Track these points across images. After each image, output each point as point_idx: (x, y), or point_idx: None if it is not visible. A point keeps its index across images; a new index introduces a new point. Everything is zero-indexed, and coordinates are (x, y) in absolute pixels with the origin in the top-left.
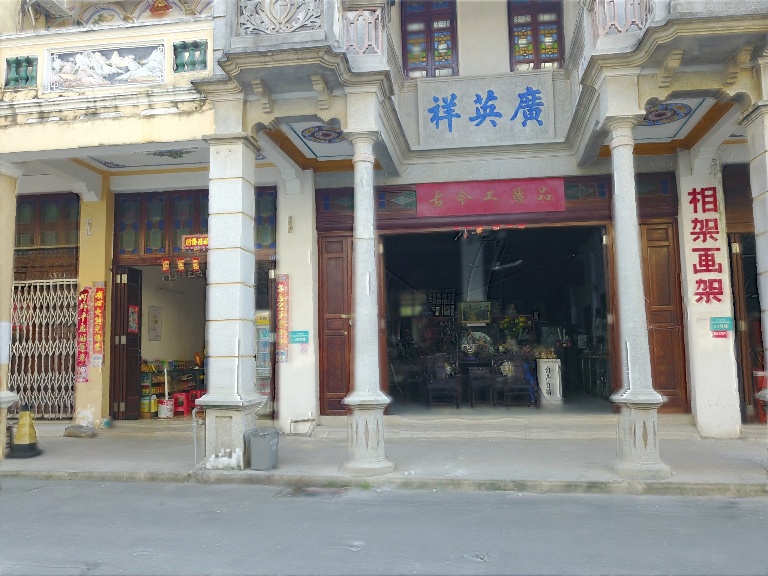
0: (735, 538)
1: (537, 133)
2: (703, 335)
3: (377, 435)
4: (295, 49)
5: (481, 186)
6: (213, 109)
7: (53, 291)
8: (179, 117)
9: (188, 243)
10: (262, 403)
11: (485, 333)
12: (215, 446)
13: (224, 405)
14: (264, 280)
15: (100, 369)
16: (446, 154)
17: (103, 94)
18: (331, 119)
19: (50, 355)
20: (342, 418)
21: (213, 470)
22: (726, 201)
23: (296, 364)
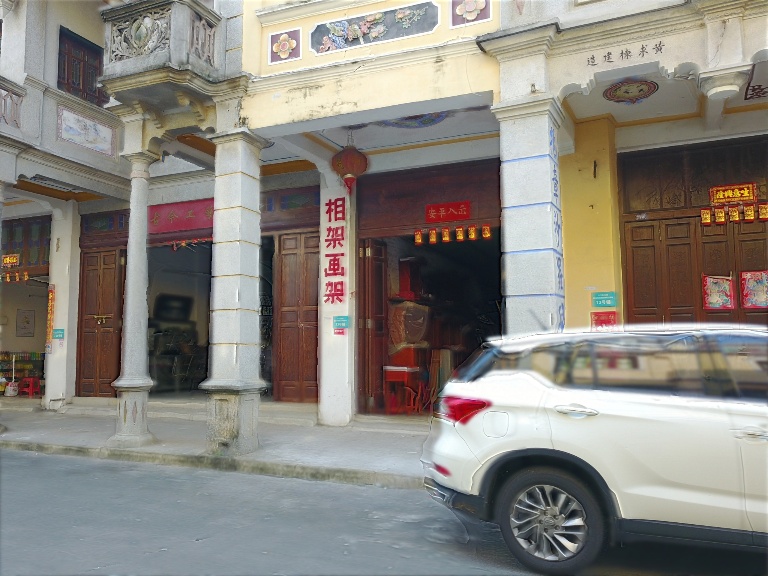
0: (18, 483)
1: None
2: (327, 332)
3: None
4: None
5: (185, 206)
6: None
7: None
8: None
9: (5, 261)
10: None
11: None
12: None
13: None
14: None
15: None
16: (158, 181)
17: None
18: None
19: None
20: (87, 399)
21: None
22: (363, 209)
23: (56, 355)
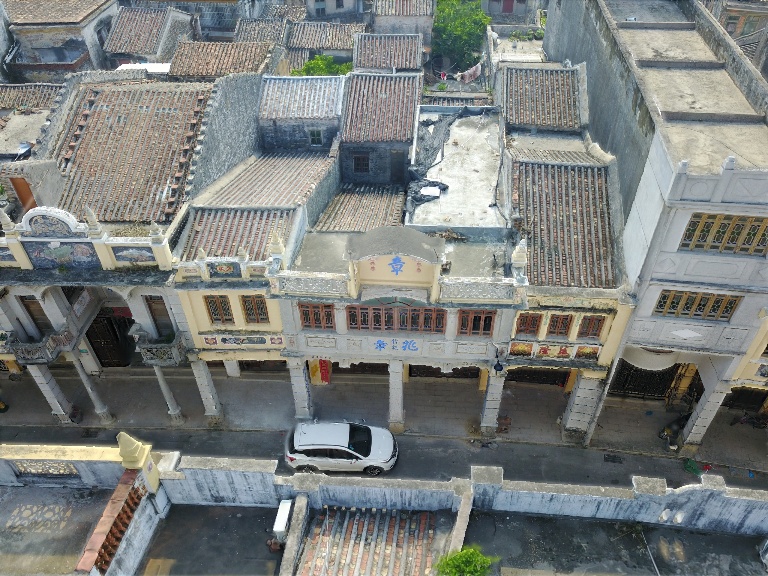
0: None
1: None
2: None
3: (107, 416)
4: None
5: None
6: None
7: None
8: (8, 354)
9: None
10: None
11: None
12: None
13: None
14: None
15: None
16: None
17: None
18: None
19: None
20: (110, 368)
21: (64, 424)
22: None
23: (86, 358)
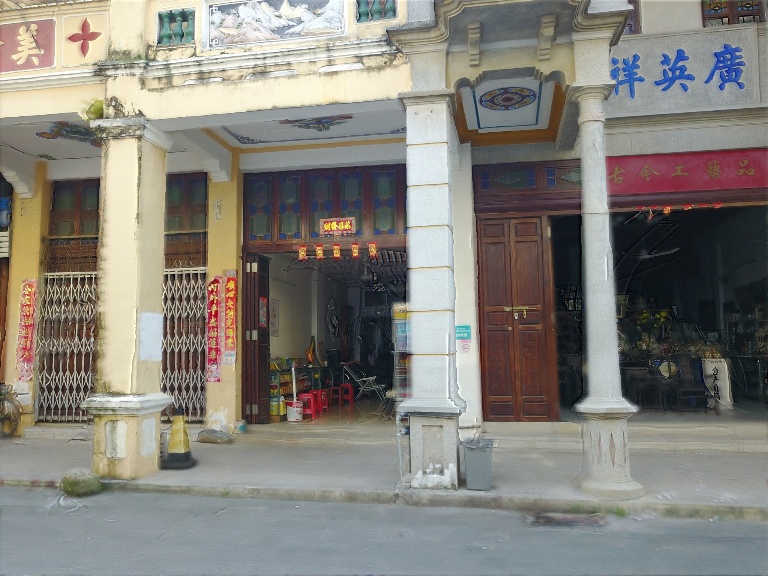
0: None
1: (738, 97)
2: None
3: (623, 450)
4: None
5: (669, 160)
6: (409, 63)
7: (178, 281)
8: (368, 73)
9: (327, 227)
10: None
11: (619, 329)
12: (422, 460)
13: (435, 412)
14: (340, 274)
15: (233, 367)
16: (629, 123)
17: (274, 49)
18: (552, 72)
19: (176, 351)
20: (510, 425)
21: (422, 489)
22: None
23: (457, 363)
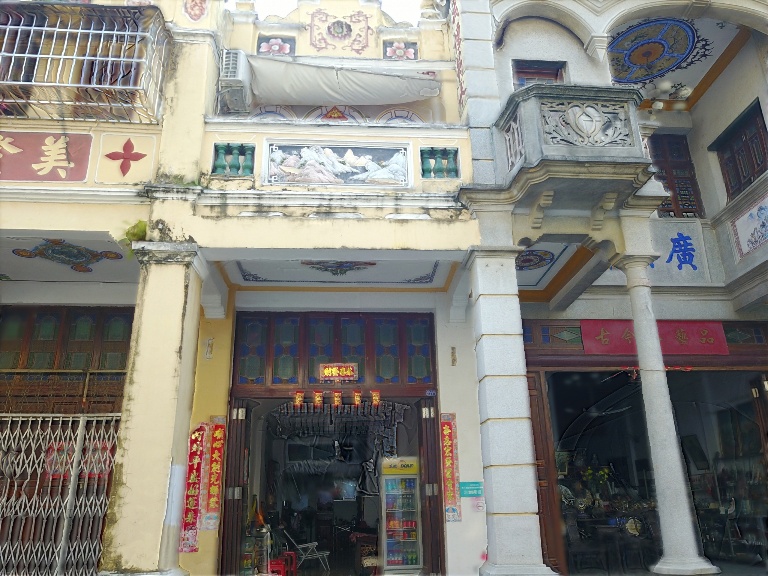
0: None
1: (693, 277)
2: None
3: None
4: (616, 163)
5: None
6: (477, 219)
7: None
8: (438, 224)
9: (327, 373)
10: (396, 575)
11: (566, 486)
12: None
13: None
14: None
15: (217, 533)
16: (611, 291)
17: (342, 192)
18: (602, 240)
19: None
20: None
21: None
22: None
23: (472, 523)
